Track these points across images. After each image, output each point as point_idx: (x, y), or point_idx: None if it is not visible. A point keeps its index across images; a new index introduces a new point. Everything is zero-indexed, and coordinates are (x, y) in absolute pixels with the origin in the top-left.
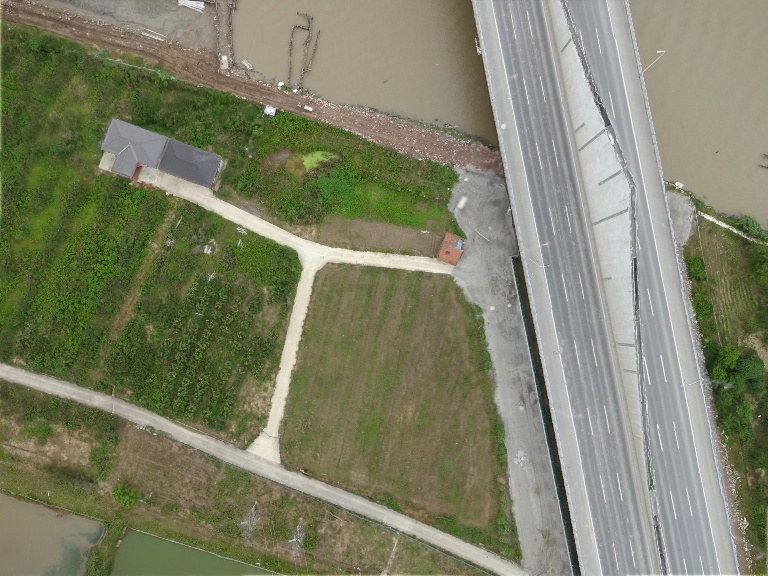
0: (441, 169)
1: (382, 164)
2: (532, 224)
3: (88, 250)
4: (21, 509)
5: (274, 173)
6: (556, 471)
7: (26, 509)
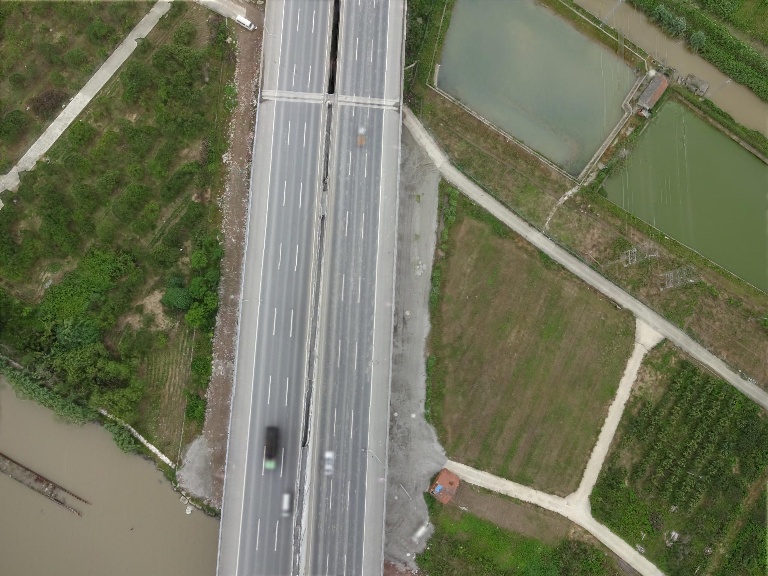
0: (432, 572)
1: None
2: (369, 497)
3: None
4: None
5: None
6: None
7: None
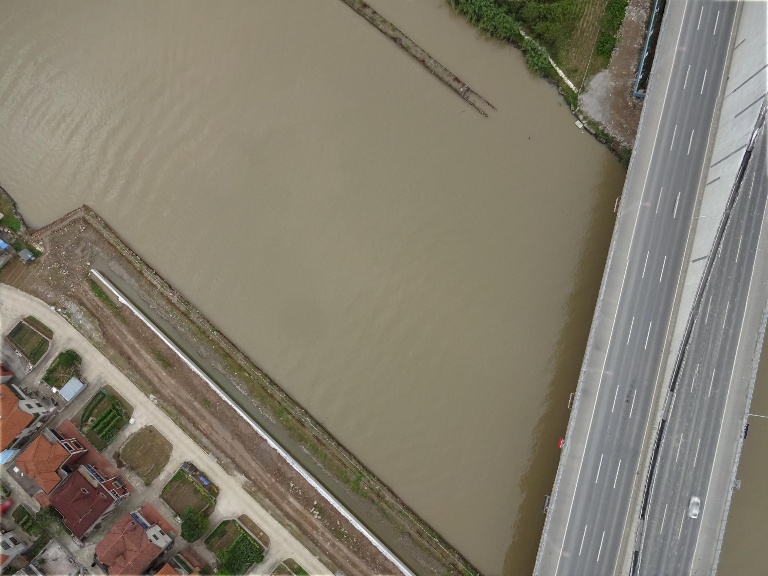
0: None
1: None
2: None
3: None
4: None
5: None
6: None
7: None
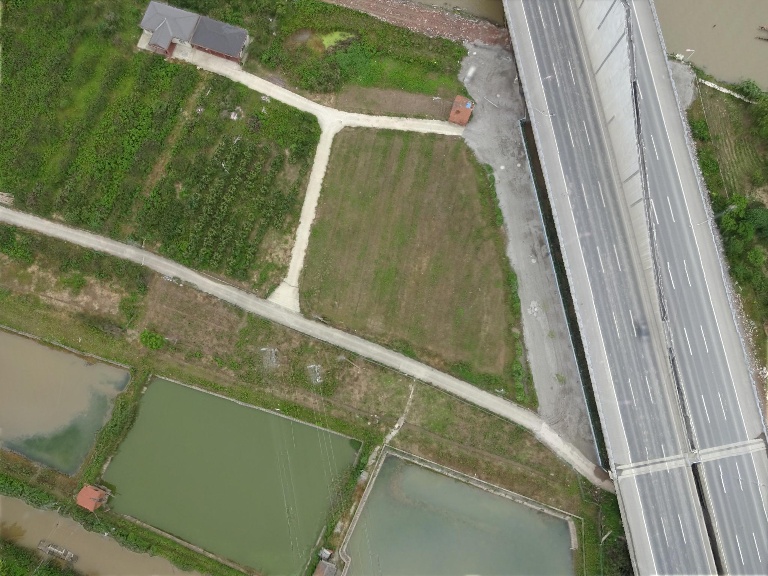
0: (451, 44)
1: (396, 40)
2: (537, 77)
3: (125, 116)
4: (53, 358)
5: (296, 50)
6: (570, 320)
7: (58, 358)
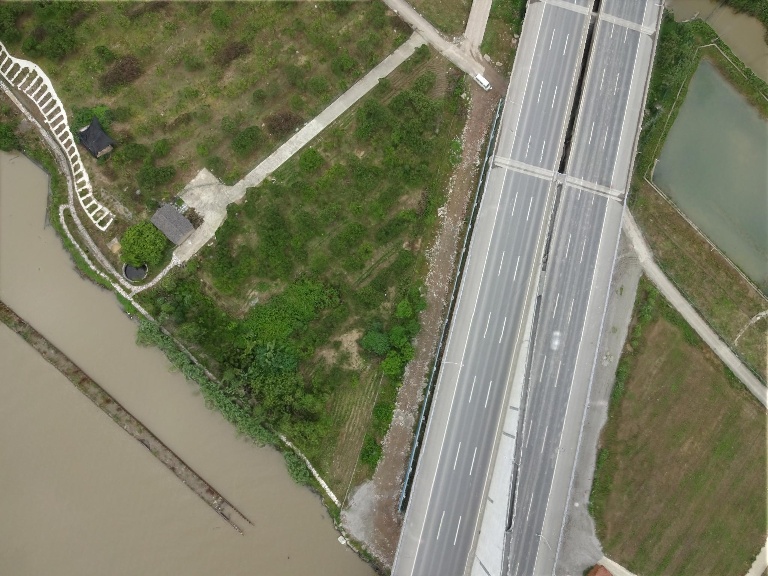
0: None
1: None
2: None
3: None
4: None
5: None
6: None
7: None
